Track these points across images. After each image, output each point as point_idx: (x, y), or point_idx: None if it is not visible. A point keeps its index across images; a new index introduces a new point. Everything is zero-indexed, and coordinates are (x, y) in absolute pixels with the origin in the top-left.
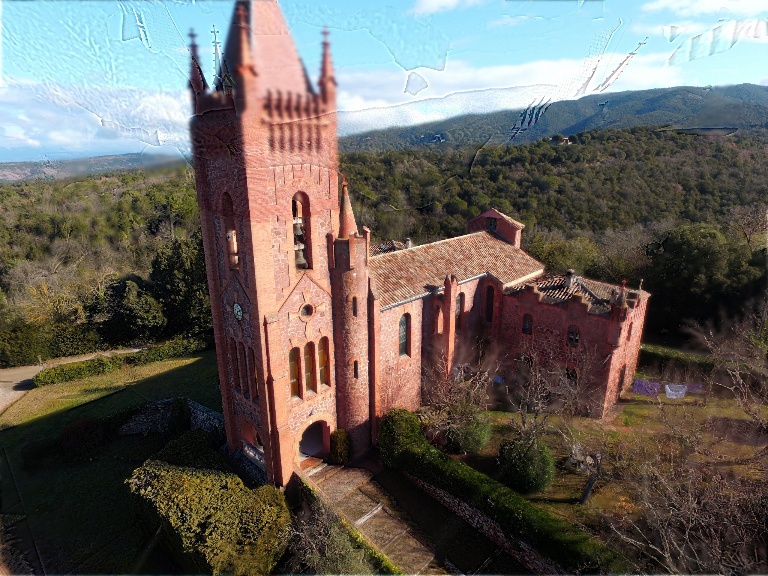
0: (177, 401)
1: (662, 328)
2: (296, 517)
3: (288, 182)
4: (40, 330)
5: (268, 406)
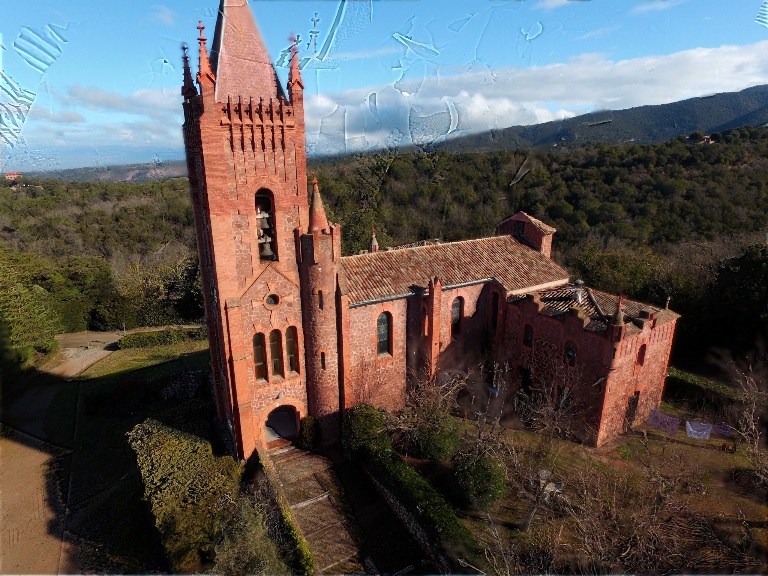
0: (202, 373)
1: (729, 358)
2: (247, 489)
3: (250, 179)
4: (132, 302)
5: (230, 384)
